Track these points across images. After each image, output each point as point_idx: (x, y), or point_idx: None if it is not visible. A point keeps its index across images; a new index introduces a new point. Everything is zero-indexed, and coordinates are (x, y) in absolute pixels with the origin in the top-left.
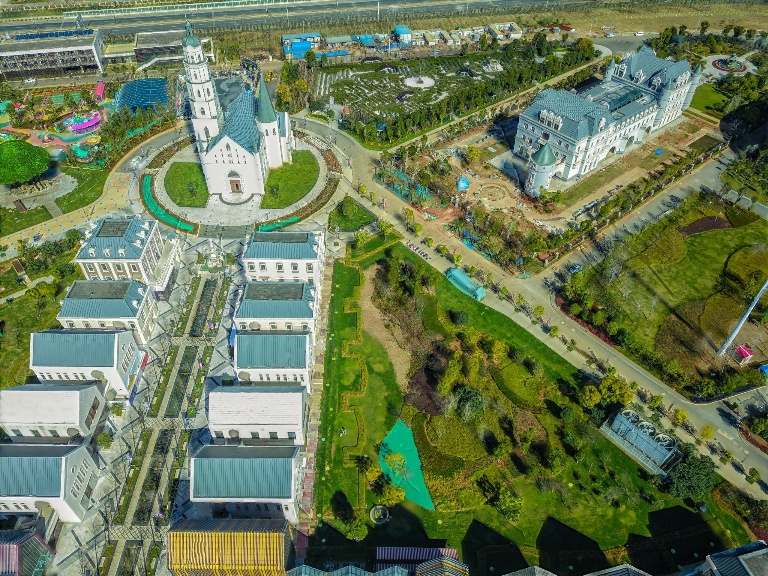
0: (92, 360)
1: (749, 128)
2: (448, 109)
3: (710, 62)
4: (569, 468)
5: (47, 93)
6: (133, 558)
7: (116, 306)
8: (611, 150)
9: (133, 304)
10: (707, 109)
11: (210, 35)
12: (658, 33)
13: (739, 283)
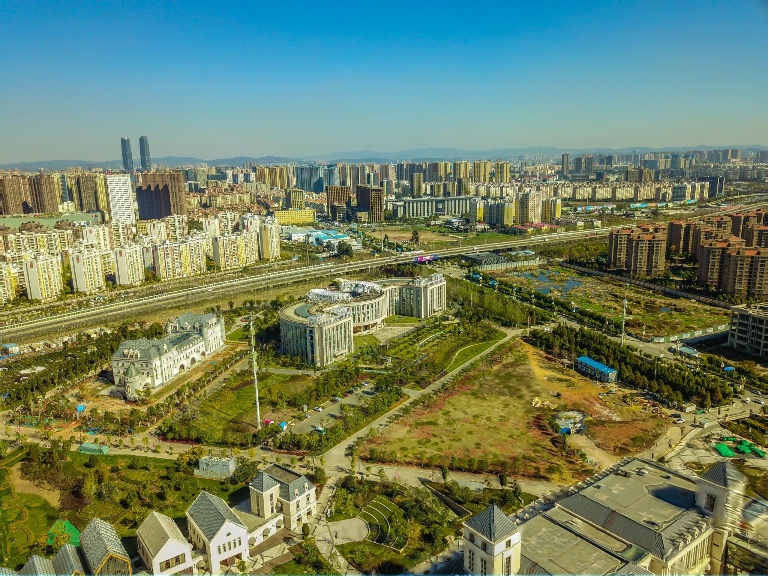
0: None
1: (263, 341)
2: (60, 377)
3: (239, 320)
4: (179, 496)
5: None
6: None
7: None
8: (182, 368)
9: None
10: (240, 339)
11: None
12: None
13: None
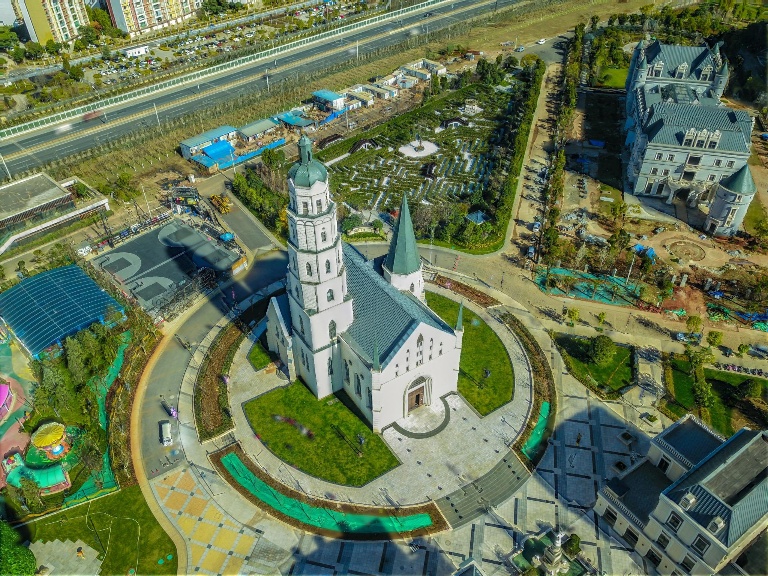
0: None
1: None
2: None
3: None
4: None
5: None
6: None
7: None
8: None
9: None
10: None
11: (51, 175)
12: (553, 38)
13: None
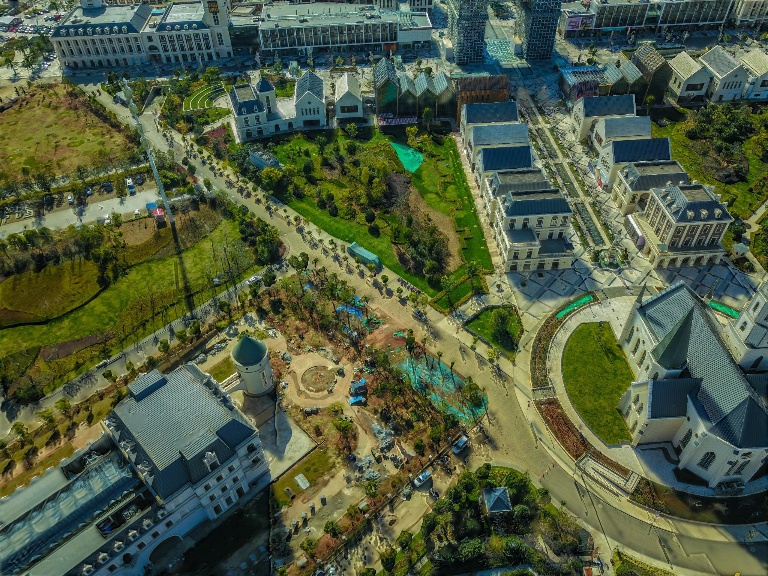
0: None
1: None
2: None
3: None
4: None
5: None
6: (534, 121)
7: None
8: None
9: None
10: None
11: None
12: None
13: (105, 273)
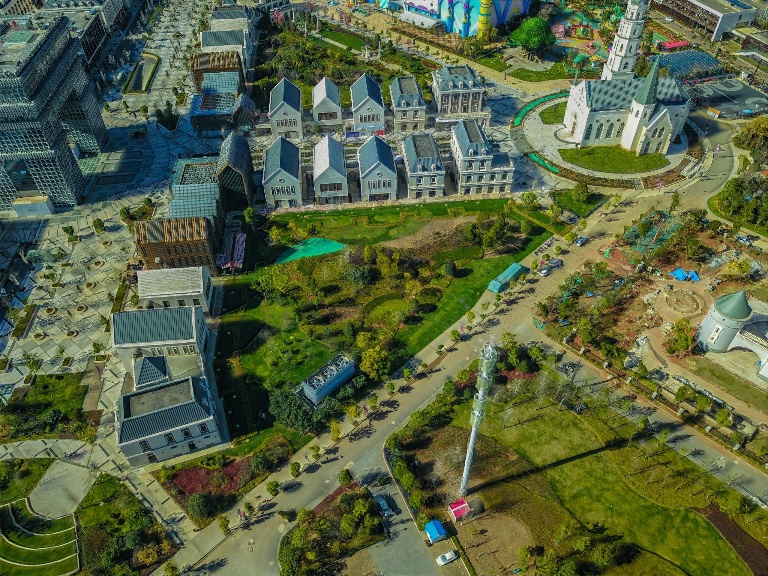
0: None
1: None
2: None
3: None
4: None
5: (657, 29)
6: None
7: None
8: None
9: None
10: None
11: None
12: None
13: None
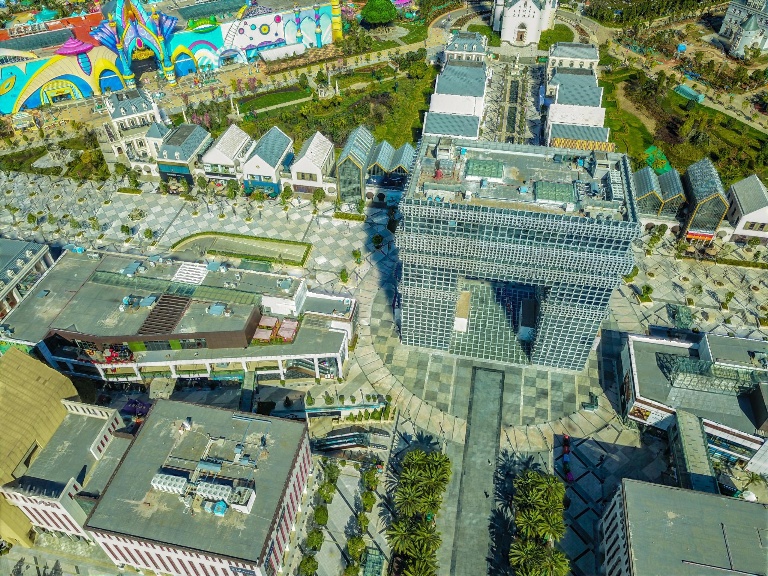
0: (471, 92)
1: None
2: (665, 8)
3: None
4: (766, 172)
5: None
6: None
7: (477, 72)
8: None
9: (486, 73)
10: None
11: None
12: None
13: None
